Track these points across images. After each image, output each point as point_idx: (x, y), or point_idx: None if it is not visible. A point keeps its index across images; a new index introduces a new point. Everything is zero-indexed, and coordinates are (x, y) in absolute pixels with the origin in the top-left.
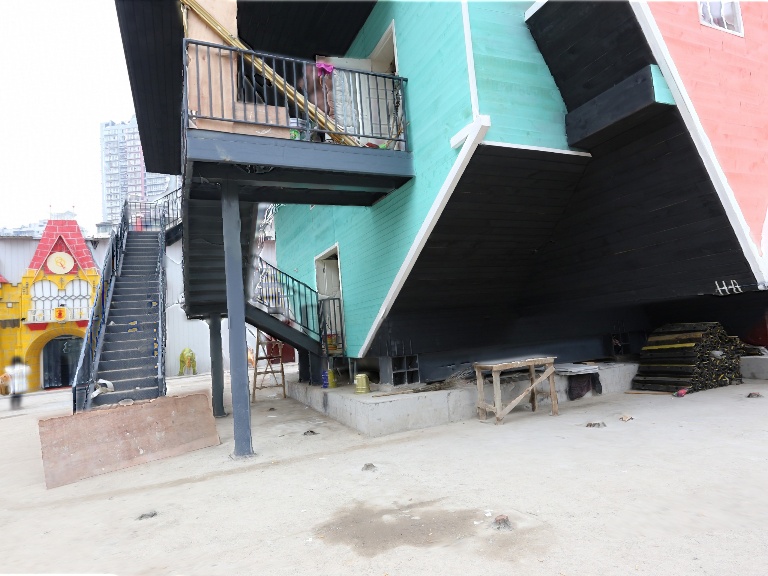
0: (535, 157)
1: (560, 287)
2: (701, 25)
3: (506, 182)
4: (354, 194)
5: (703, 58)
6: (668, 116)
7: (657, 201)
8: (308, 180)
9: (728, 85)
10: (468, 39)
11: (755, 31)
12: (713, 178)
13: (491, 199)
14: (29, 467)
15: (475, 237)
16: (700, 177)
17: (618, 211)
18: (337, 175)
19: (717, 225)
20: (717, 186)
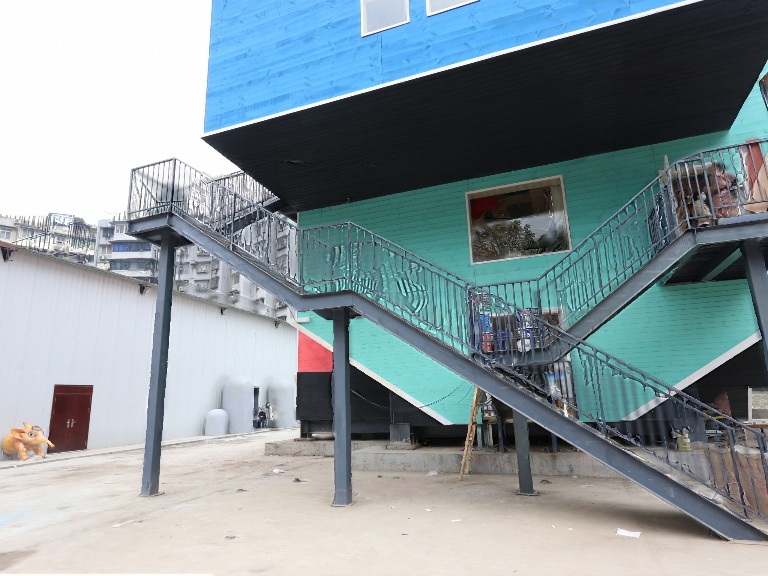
0: None
1: (734, 371)
2: None
3: None
4: None
5: None
6: None
7: None
8: None
9: None
10: None
11: None
12: None
13: None
14: (728, 560)
15: None
16: None
17: None
18: None
19: None
20: None
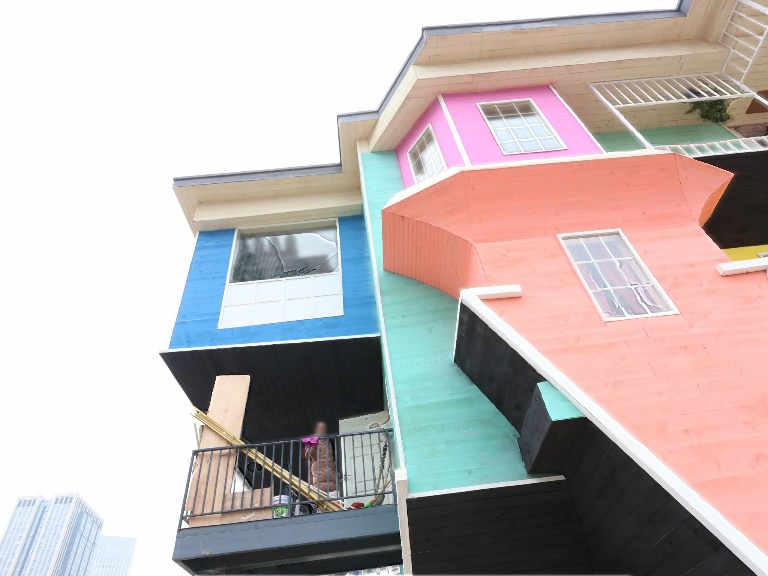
0: (489, 496)
1: None
2: (607, 322)
3: (472, 530)
4: (382, 552)
5: (618, 354)
6: (587, 429)
7: (650, 530)
8: (310, 552)
9: (670, 370)
10: (392, 396)
11: (695, 302)
12: (675, 496)
13: (467, 552)
14: None
15: None
16: (662, 496)
17: (628, 546)
18: (339, 541)
19: (728, 563)
20: (686, 506)
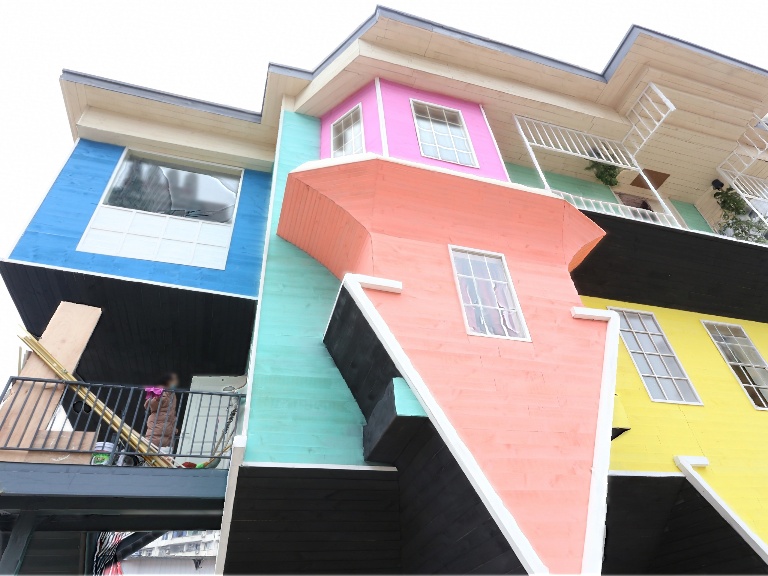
0: (322, 476)
1: None
2: (469, 336)
3: (298, 506)
4: (205, 516)
5: (471, 366)
6: (427, 428)
7: (456, 527)
8: (124, 506)
9: (510, 390)
10: (252, 362)
11: (547, 335)
12: (483, 500)
13: (288, 526)
14: None
15: (290, 575)
16: (473, 498)
17: (435, 539)
18: None
19: (511, 564)
20: (490, 510)
